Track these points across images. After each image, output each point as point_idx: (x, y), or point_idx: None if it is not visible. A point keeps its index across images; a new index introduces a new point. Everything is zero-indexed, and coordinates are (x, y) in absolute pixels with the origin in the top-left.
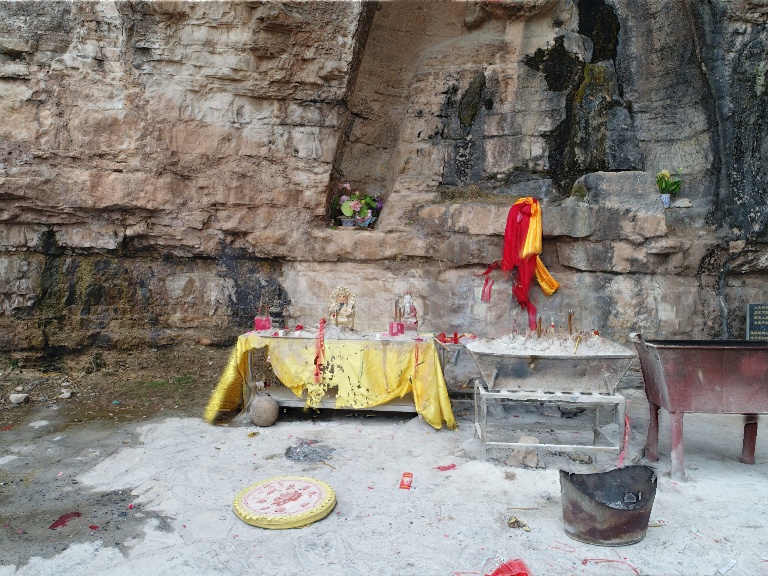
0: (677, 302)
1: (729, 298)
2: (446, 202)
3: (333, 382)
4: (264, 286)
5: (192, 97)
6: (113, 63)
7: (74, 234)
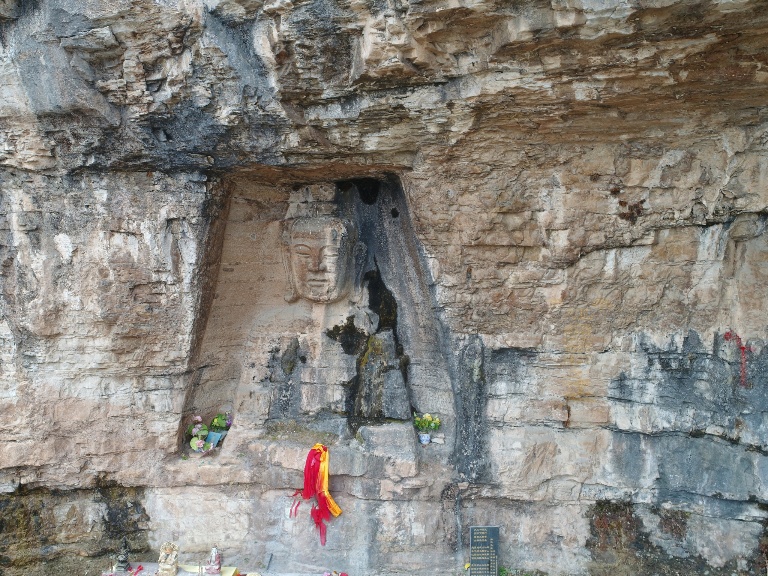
0: (426, 521)
1: (463, 517)
2: (268, 439)
3: None
4: (130, 507)
5: (69, 382)
6: (8, 365)
7: None
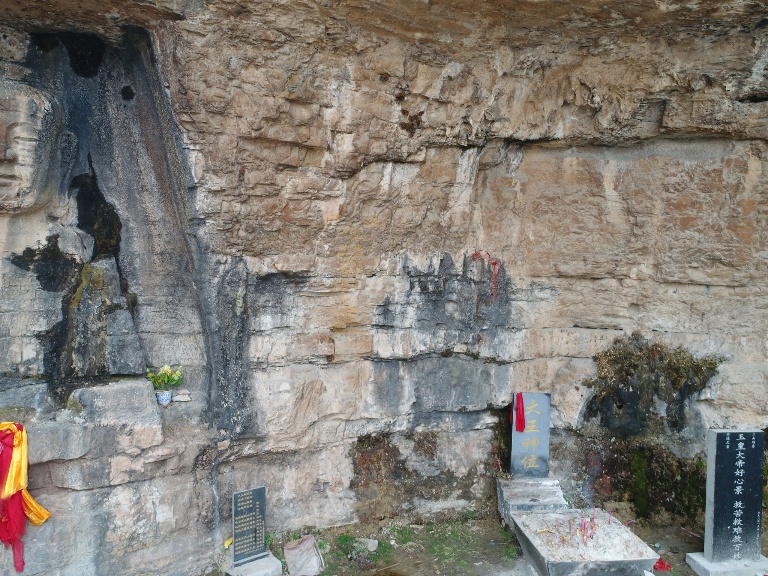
0: (174, 501)
1: (220, 485)
2: None
3: None
4: None
5: None
6: None
7: None
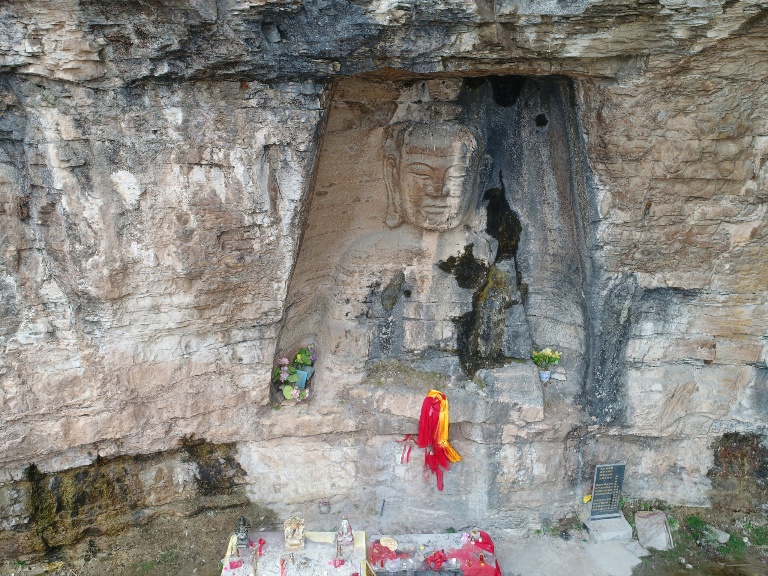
0: (547, 461)
1: (585, 454)
2: (372, 383)
3: None
4: (223, 463)
5: (143, 345)
6: (65, 332)
7: (53, 463)
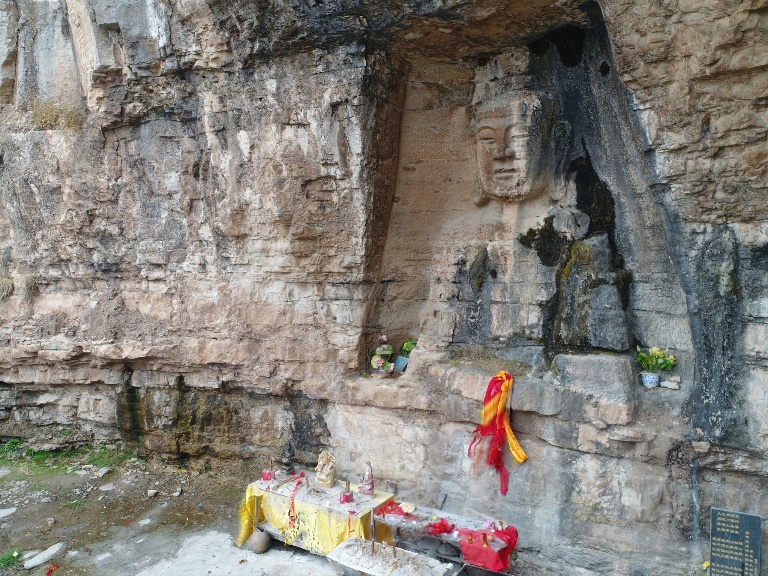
0: (643, 490)
1: (703, 494)
2: (449, 363)
3: (299, 531)
4: (314, 420)
5: (259, 286)
6: (211, 266)
7: (194, 378)
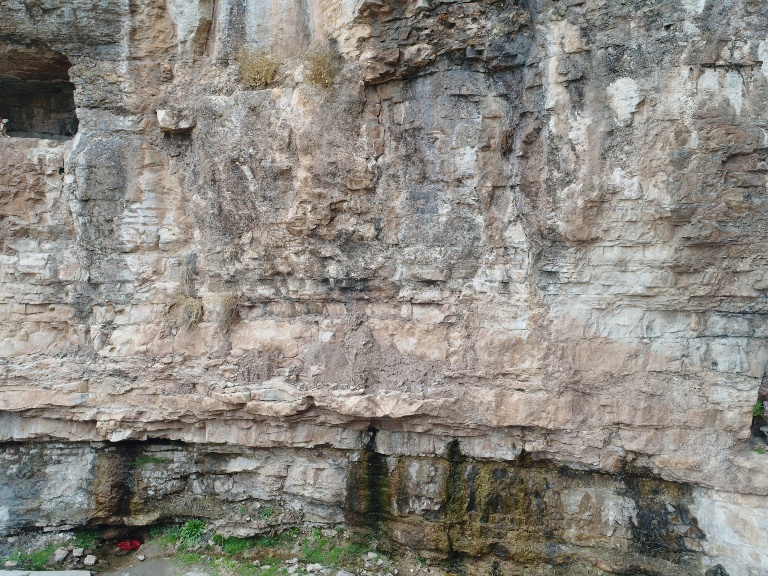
0: None
1: None
2: None
3: None
4: (671, 512)
5: (598, 314)
6: (518, 285)
7: (476, 445)
